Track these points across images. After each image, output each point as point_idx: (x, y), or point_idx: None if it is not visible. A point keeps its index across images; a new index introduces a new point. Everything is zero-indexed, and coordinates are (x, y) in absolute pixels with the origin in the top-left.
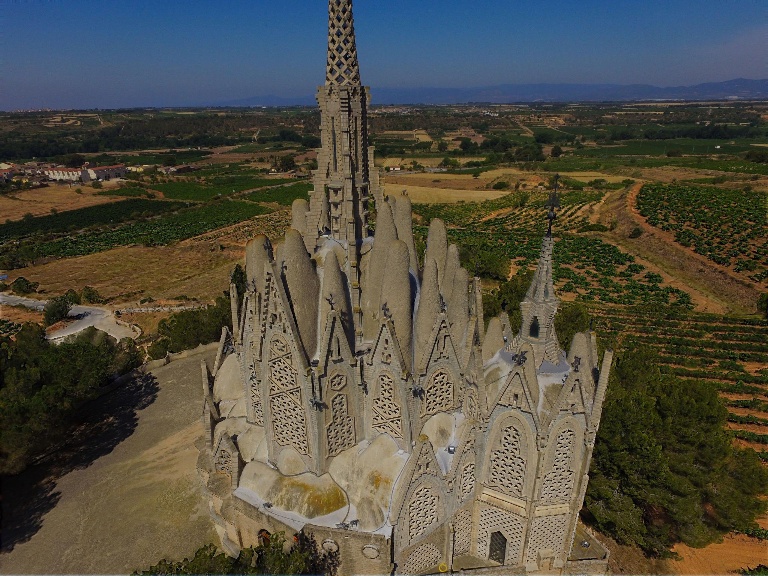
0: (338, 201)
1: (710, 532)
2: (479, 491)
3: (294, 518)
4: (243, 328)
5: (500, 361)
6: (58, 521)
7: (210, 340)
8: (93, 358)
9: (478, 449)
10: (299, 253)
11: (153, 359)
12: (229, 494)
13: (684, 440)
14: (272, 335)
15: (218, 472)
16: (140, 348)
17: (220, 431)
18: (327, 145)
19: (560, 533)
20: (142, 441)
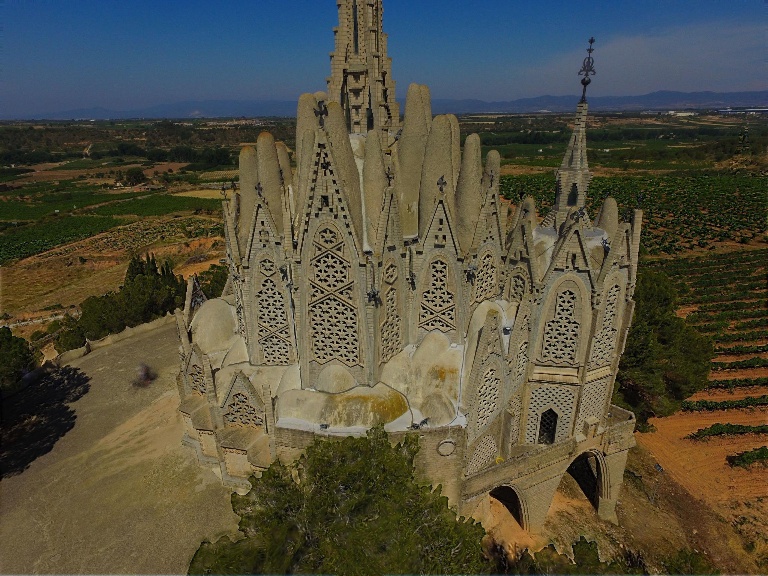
0: (361, 87)
1: (671, 403)
2: (530, 372)
3: (360, 431)
4: (251, 246)
5: (541, 236)
6: (6, 535)
7: (137, 322)
8: (8, 336)
9: (532, 324)
10: (343, 128)
11: (67, 350)
12: (251, 443)
13: (651, 321)
14: (318, 225)
15: (226, 427)
16: (33, 350)
17: (223, 378)
18: (346, 24)
19: (601, 398)
20: (91, 431)
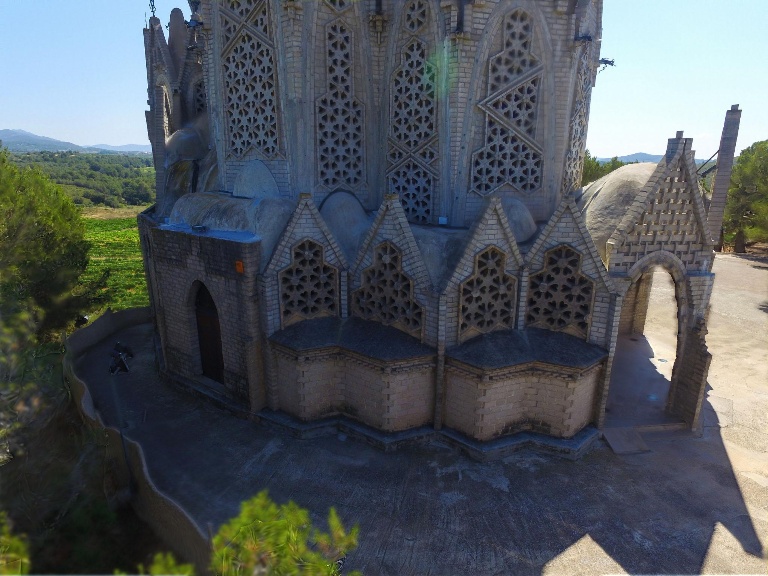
0: None
1: None
2: None
3: None
4: None
5: None
6: (759, 315)
7: None
8: None
9: None
10: None
11: None
12: None
13: None
14: None
15: None
16: None
17: None
18: None
19: None
20: None
